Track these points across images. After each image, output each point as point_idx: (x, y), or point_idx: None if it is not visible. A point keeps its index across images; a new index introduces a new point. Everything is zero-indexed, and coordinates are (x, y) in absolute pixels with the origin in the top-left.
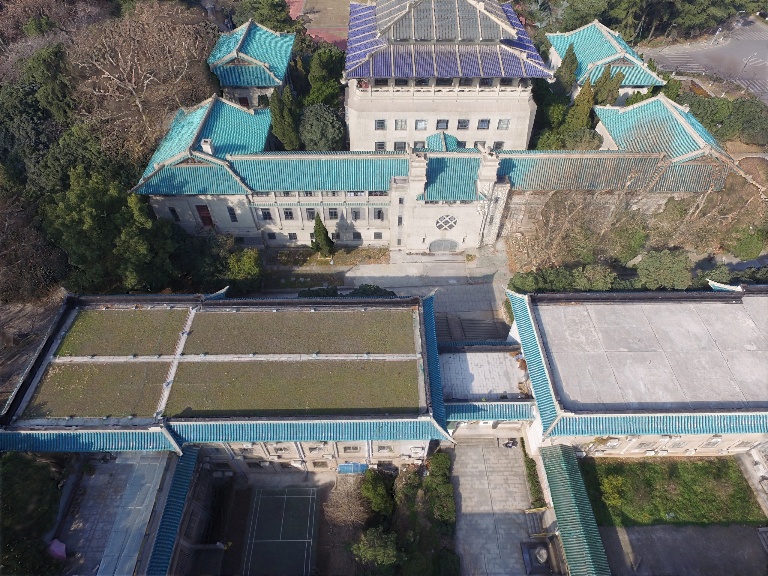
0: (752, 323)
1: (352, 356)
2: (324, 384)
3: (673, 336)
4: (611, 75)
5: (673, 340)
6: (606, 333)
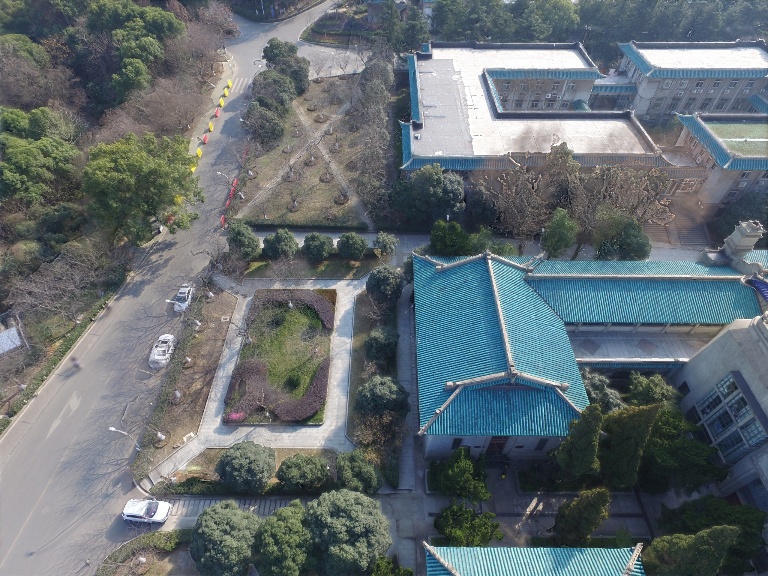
0: (506, 147)
1: (754, 140)
2: (759, 131)
3: (560, 142)
4: (562, 573)
5: (560, 140)
6: (602, 144)
